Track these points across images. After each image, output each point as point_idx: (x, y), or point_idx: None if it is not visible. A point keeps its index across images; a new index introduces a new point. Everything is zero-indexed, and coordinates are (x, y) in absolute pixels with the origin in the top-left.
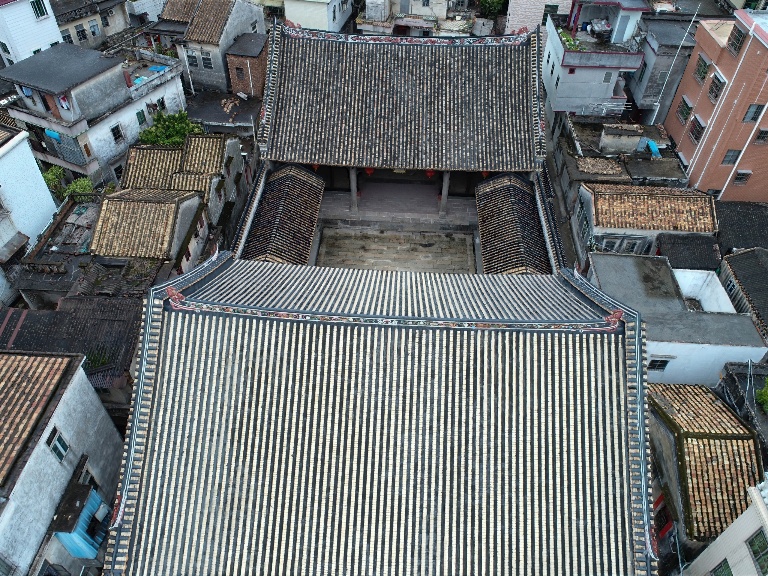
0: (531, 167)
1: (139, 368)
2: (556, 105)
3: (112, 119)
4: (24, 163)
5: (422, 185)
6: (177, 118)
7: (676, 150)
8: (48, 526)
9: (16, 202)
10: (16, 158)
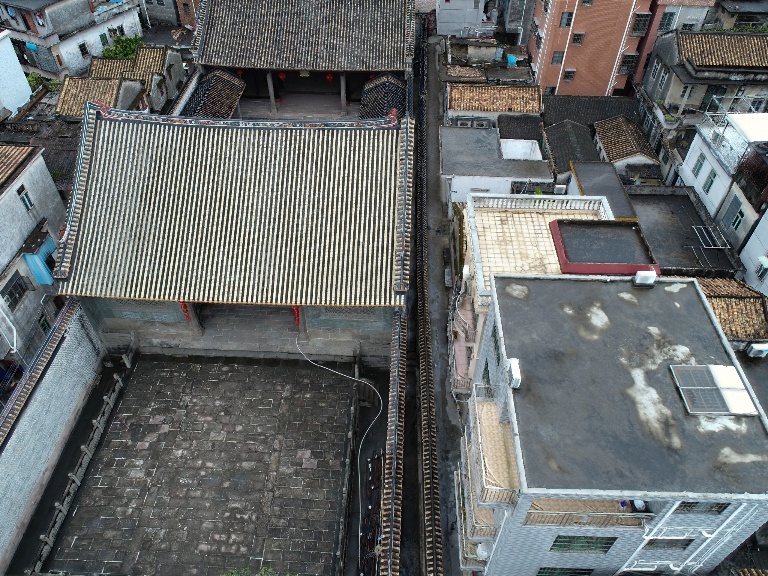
0: (403, 67)
1: (79, 151)
2: (439, 29)
3: (79, 37)
4: (8, 55)
5: (332, 95)
6: (133, 40)
7: (532, 62)
8: (19, 249)
9: (2, 84)
10: (1, 50)
